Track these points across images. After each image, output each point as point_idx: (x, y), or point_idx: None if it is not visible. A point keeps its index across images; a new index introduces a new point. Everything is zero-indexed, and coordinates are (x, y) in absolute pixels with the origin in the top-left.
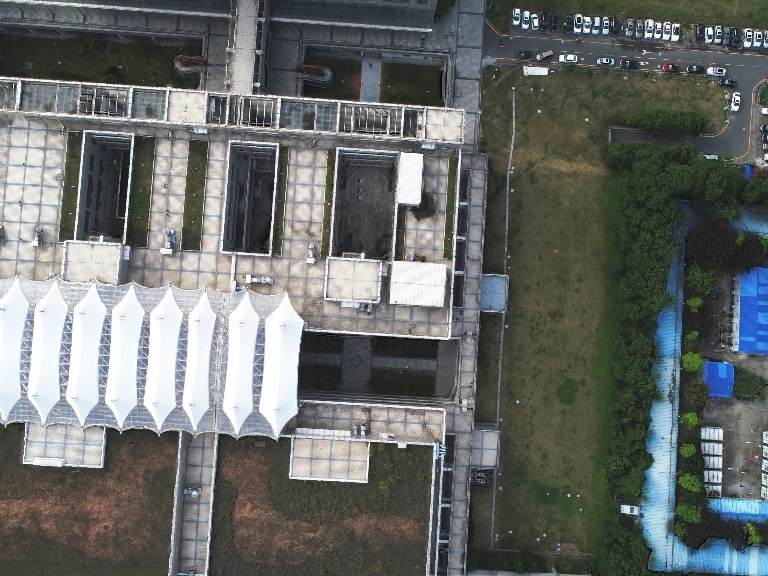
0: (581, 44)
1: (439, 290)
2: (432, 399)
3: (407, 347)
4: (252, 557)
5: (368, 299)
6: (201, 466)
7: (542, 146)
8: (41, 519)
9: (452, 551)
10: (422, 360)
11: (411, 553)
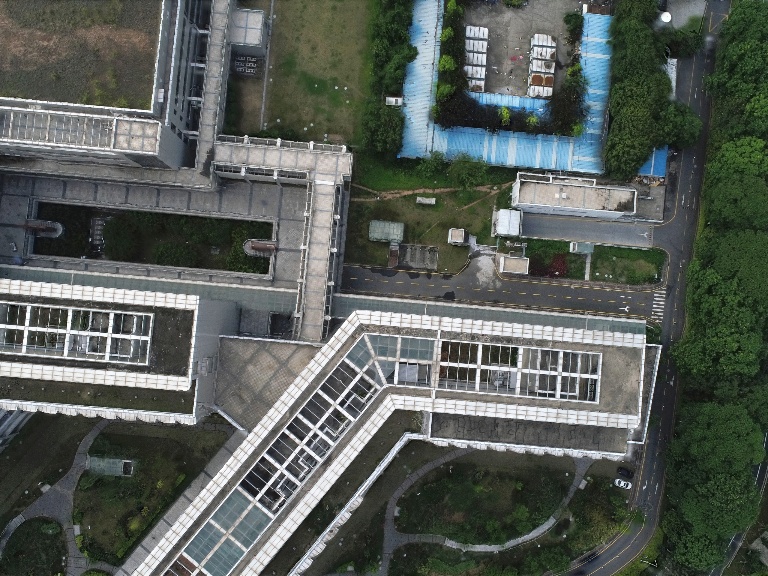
0: None
1: None
2: None
3: None
4: None
5: None
6: None
7: None
8: None
9: (205, 108)
10: None
11: (141, 64)
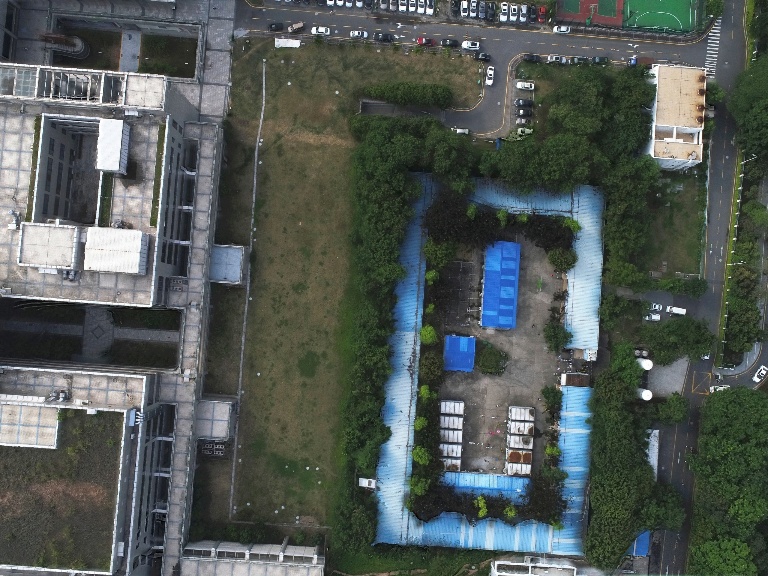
0: (335, 17)
1: (134, 256)
2: (159, 369)
3: (144, 318)
4: None
5: (63, 265)
6: None
7: (291, 118)
8: None
9: (170, 521)
10: (165, 332)
11: (99, 519)
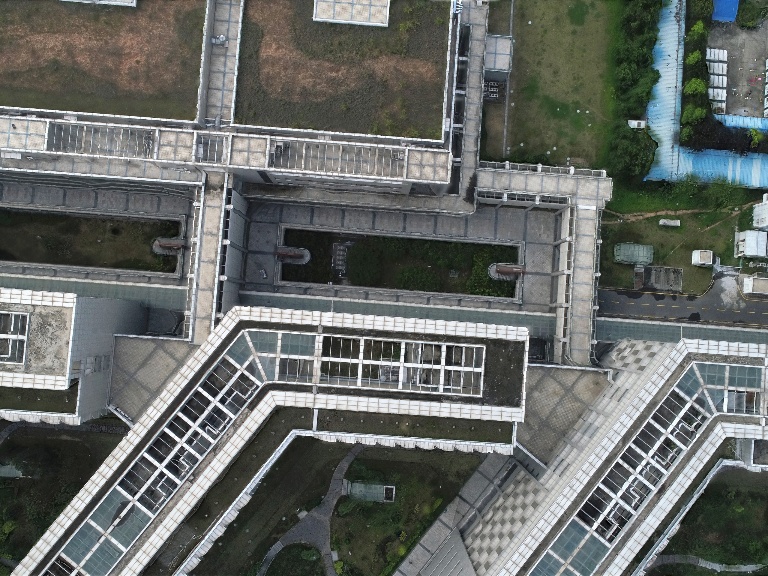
0: None
1: None
2: None
3: None
4: (277, 93)
5: None
6: (228, 22)
7: None
8: (76, 52)
9: (466, 135)
10: None
11: (429, 94)
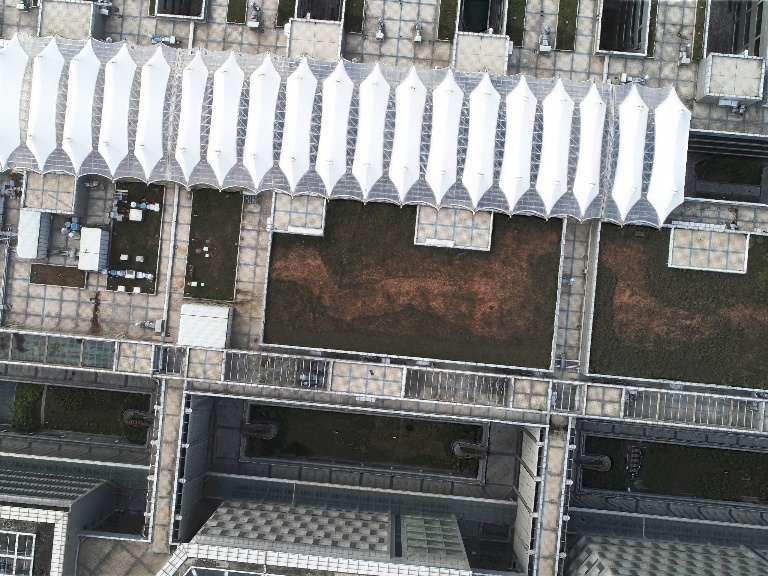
0: None
1: None
2: None
3: (737, 169)
4: (630, 341)
5: (749, 96)
6: (572, 258)
7: None
8: (430, 297)
9: None
10: (745, 186)
11: None
